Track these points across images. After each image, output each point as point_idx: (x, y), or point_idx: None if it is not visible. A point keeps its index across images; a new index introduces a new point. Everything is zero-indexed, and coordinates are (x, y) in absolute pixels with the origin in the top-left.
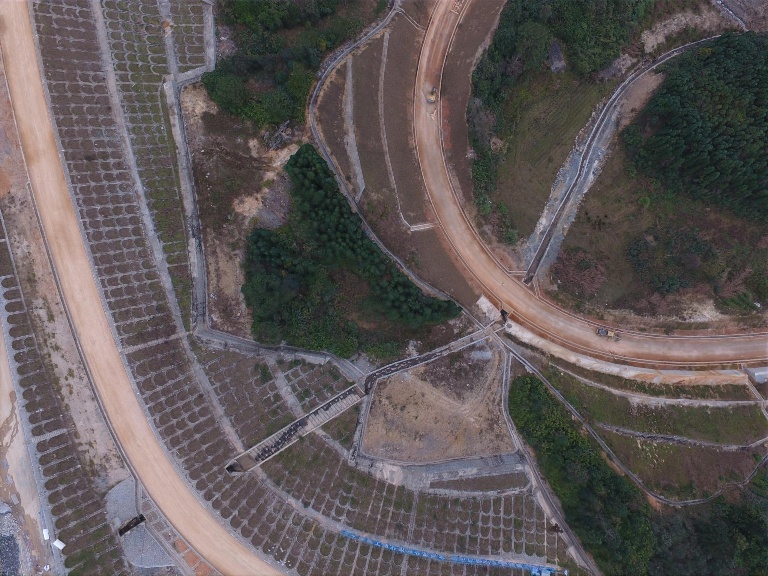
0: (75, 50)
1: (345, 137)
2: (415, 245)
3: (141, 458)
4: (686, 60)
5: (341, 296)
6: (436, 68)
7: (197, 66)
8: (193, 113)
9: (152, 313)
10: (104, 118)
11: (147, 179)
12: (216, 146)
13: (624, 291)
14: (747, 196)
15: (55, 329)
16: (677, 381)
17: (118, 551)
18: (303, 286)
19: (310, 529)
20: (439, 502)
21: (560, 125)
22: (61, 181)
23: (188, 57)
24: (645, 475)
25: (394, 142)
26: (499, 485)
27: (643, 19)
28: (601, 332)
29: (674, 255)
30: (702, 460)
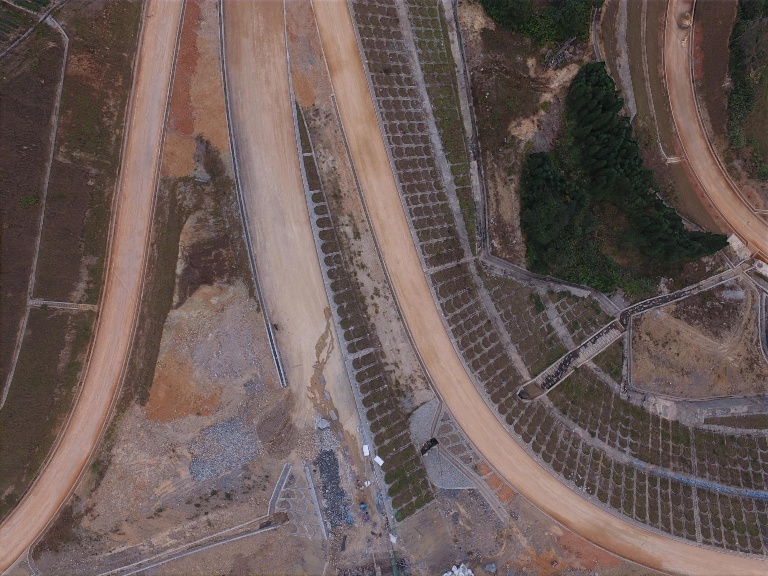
0: None
1: (617, 59)
2: (671, 178)
3: (444, 380)
4: None
5: (599, 229)
6: None
7: None
8: (472, 29)
9: (445, 235)
10: (394, 31)
11: (433, 97)
12: (495, 65)
13: None
14: None
15: (361, 247)
16: None
17: (422, 471)
18: None
19: (599, 458)
20: (715, 438)
21: None
22: (365, 94)
23: None
24: None
25: (652, 68)
26: None
27: None
28: None
29: None
30: None
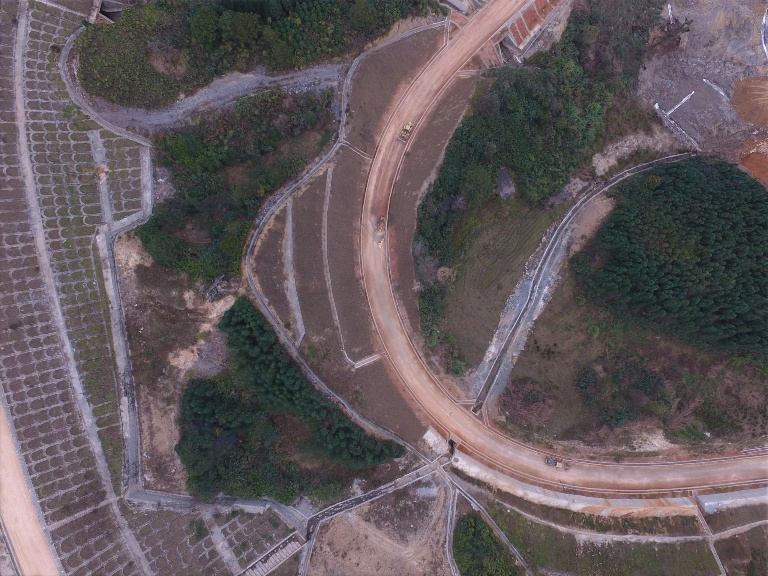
0: (1, 212)
1: (285, 282)
2: (359, 383)
3: None
4: (636, 188)
5: (282, 439)
6: (383, 196)
7: (133, 212)
8: (126, 266)
9: (80, 482)
10: (32, 280)
11: (77, 340)
12: (150, 300)
13: (573, 422)
14: (695, 331)
15: None
16: (626, 513)
17: None
18: (242, 433)
19: None
20: None
21: (510, 251)
22: None
23: (124, 203)
24: None
25: (338, 277)
26: None
27: (594, 142)
28: (550, 462)
29: (622, 389)
30: None
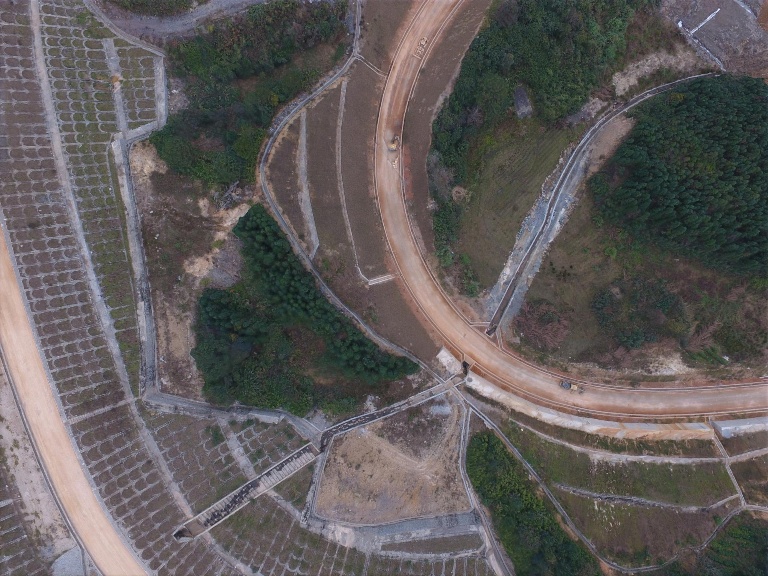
0: (18, 113)
1: (299, 193)
2: (373, 299)
3: (87, 528)
4: (657, 105)
5: (297, 353)
6: (398, 115)
7: (148, 121)
8: (142, 173)
9: (99, 380)
10: (49, 182)
11: (94, 243)
12: (165, 206)
13: (588, 344)
14: (716, 250)
15: None
16: (641, 436)
17: None
18: (257, 344)
19: None
20: (390, 565)
21: (526, 172)
22: (4, 251)
23: (138, 112)
24: (599, 540)
25: (352, 194)
26: (452, 547)
27: (614, 60)
28: (564, 385)
29: (639, 309)
30: (660, 522)
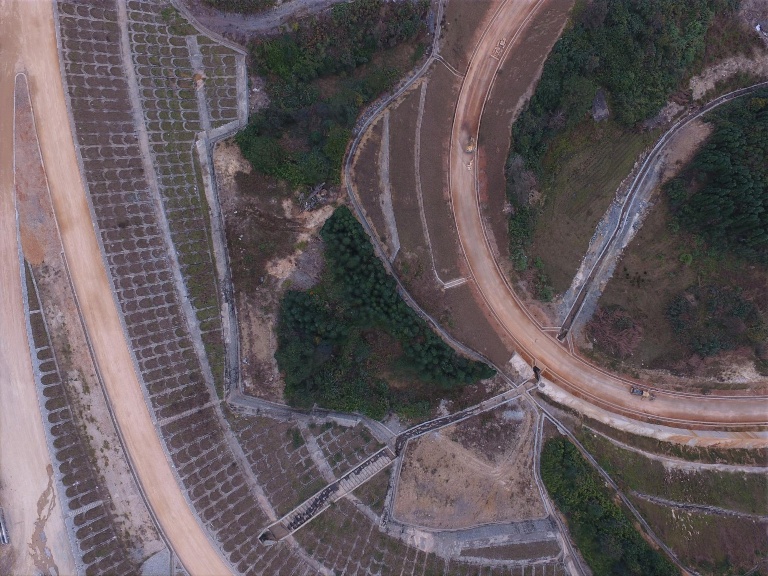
0: (107, 111)
1: (380, 195)
2: (449, 303)
3: (176, 530)
4: (737, 111)
5: (373, 356)
6: (474, 116)
7: (230, 120)
8: (226, 173)
9: (186, 382)
10: (137, 181)
11: (180, 243)
12: (249, 207)
13: (661, 351)
14: None
15: (90, 401)
16: (713, 444)
17: None
18: (335, 347)
19: None
20: (470, 570)
21: (601, 176)
22: (95, 250)
23: (220, 111)
24: (680, 549)
25: (429, 196)
26: (530, 553)
27: (692, 64)
28: (636, 391)
29: (716, 317)
30: (738, 532)
